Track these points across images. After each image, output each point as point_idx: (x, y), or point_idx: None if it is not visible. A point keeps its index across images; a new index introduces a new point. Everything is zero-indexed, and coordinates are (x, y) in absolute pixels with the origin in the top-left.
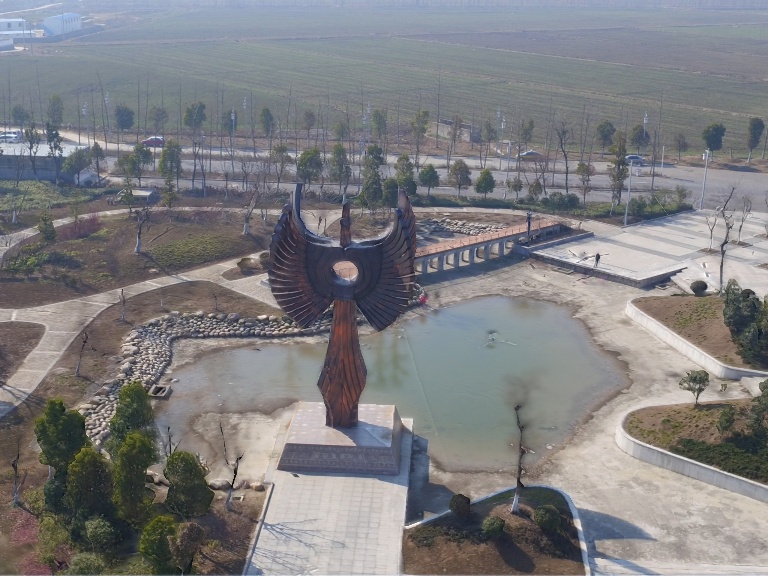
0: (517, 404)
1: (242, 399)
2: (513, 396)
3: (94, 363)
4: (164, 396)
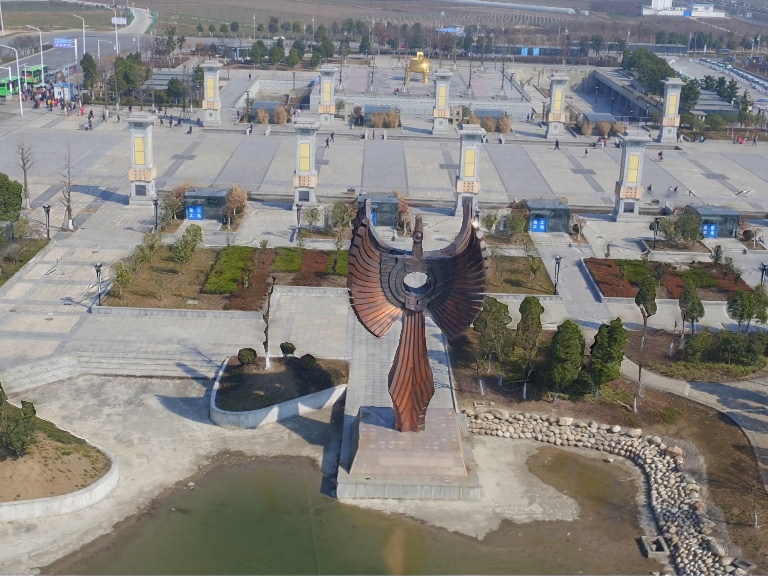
0: (199, 553)
1: (549, 543)
2: (198, 568)
3: (762, 550)
4: (642, 537)
